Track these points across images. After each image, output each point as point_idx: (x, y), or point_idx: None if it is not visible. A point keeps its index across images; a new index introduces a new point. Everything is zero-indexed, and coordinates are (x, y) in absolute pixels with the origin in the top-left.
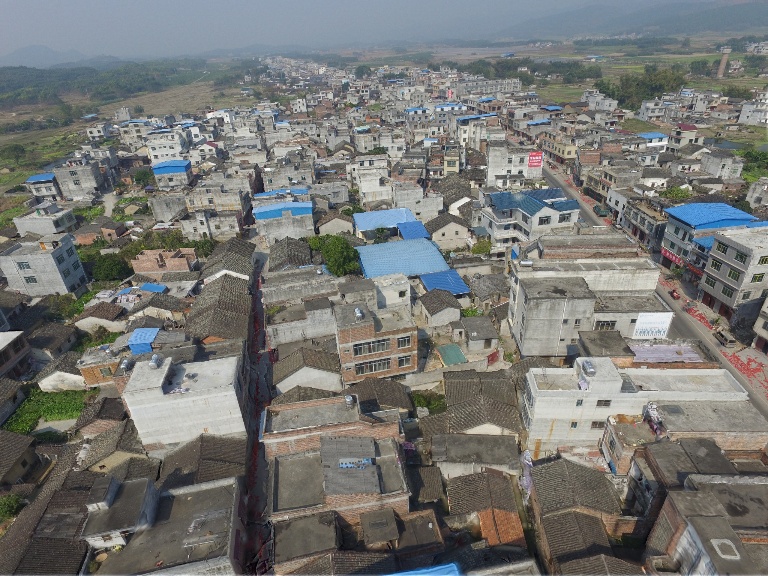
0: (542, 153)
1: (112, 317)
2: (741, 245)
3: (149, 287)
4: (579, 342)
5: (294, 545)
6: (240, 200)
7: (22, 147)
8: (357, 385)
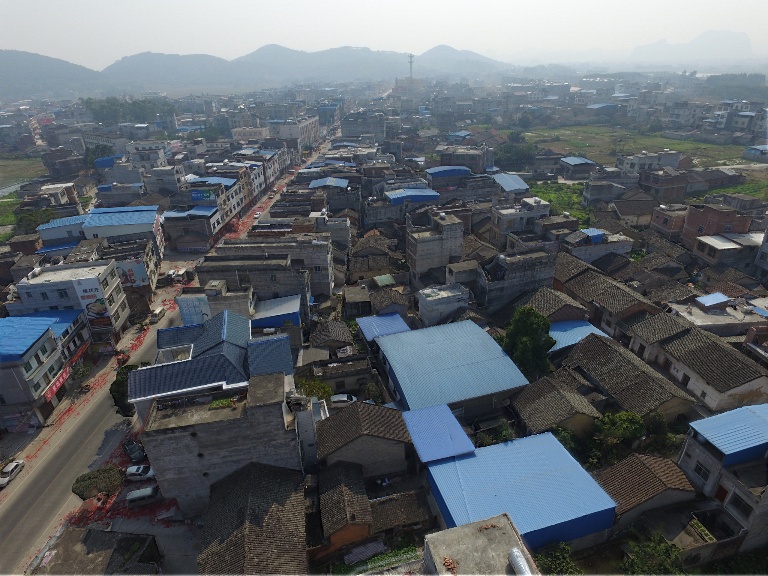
0: None
1: (710, 290)
2: None
3: (716, 297)
4: None
5: None
6: None
7: None
8: None
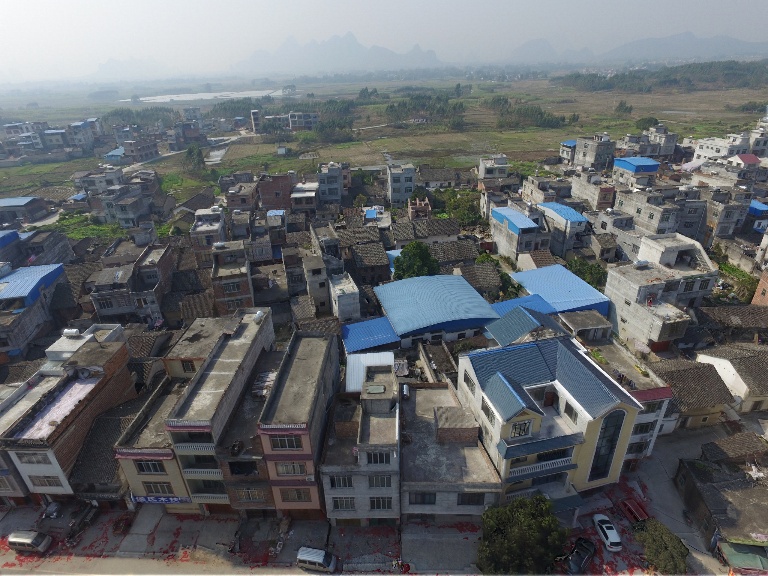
0: None
1: None
2: None
3: (370, 212)
4: None
5: (97, 274)
6: (543, 202)
7: (655, 121)
8: None
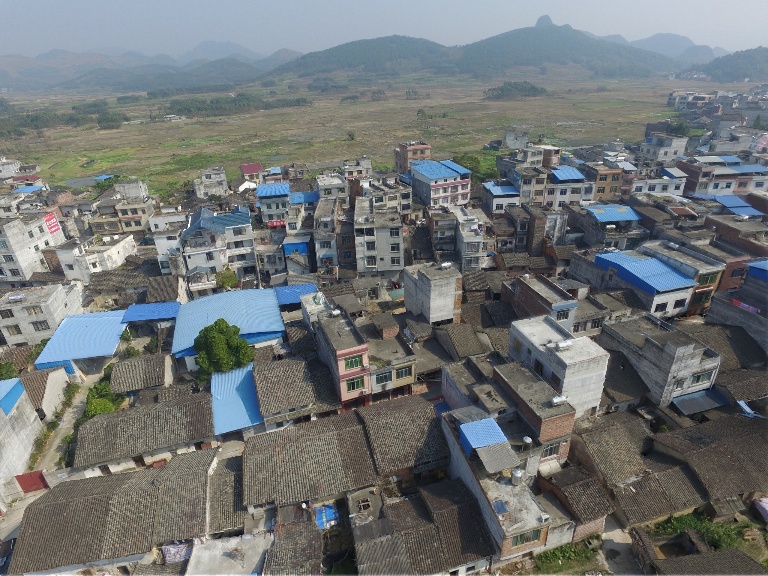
0: (54, 214)
1: None
2: (339, 184)
3: None
4: (436, 225)
5: None
6: None
7: None
8: (464, 317)
